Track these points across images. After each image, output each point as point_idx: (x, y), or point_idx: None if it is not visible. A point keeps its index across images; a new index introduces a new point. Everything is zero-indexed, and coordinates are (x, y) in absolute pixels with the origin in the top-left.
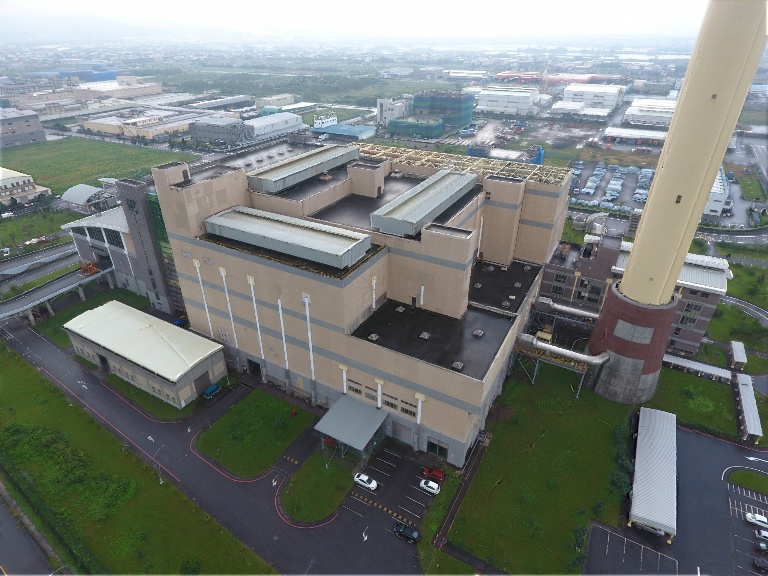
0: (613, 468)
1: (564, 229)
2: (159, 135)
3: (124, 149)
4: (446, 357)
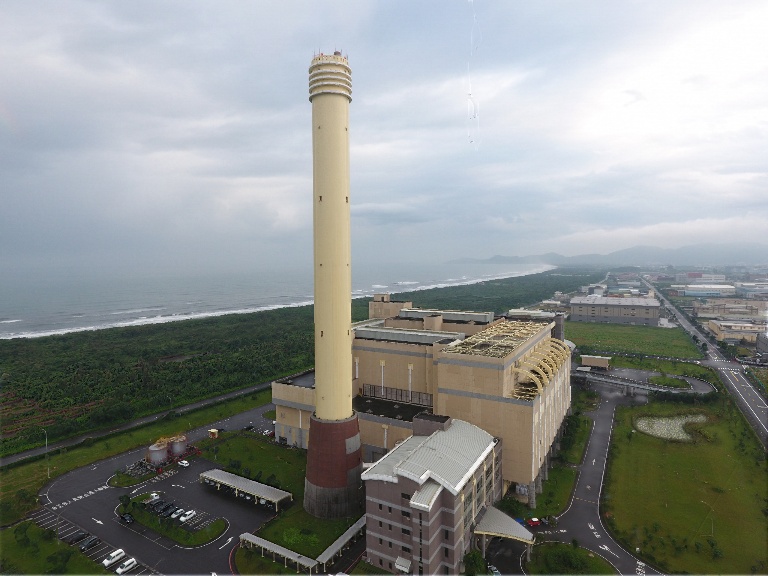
0: (252, 478)
1: (765, 561)
2: (726, 338)
3: (676, 341)
4: (298, 381)
